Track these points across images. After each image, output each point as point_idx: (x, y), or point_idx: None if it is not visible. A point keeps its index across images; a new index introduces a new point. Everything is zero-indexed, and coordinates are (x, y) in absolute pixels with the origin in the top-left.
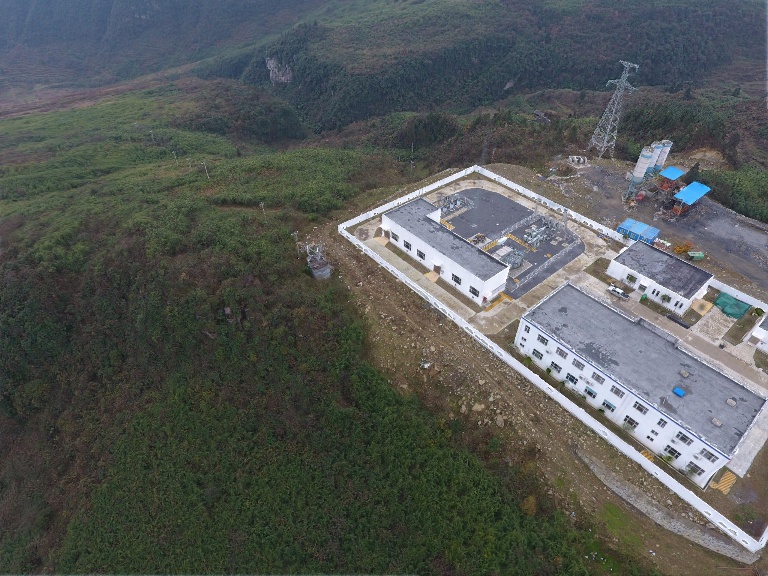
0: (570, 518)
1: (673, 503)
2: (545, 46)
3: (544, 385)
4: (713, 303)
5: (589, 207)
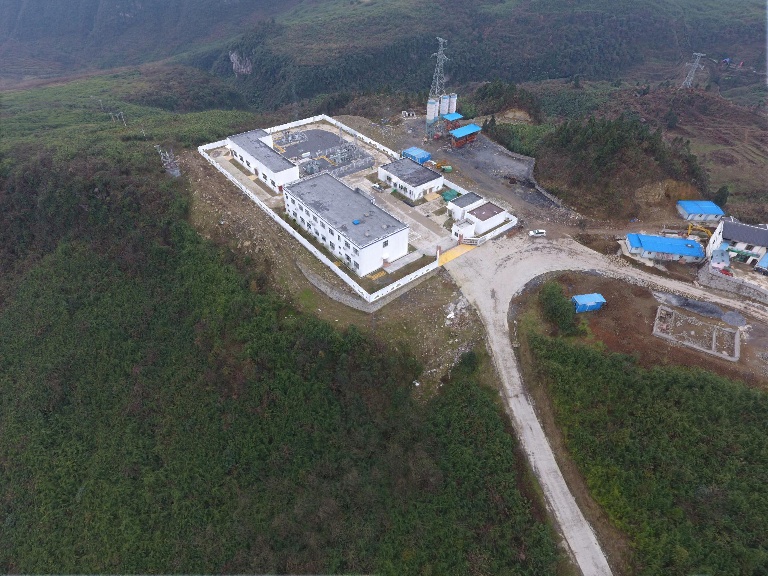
0: (282, 298)
1: (337, 283)
2: (477, 45)
3: (291, 230)
4: (441, 195)
5: (396, 142)
